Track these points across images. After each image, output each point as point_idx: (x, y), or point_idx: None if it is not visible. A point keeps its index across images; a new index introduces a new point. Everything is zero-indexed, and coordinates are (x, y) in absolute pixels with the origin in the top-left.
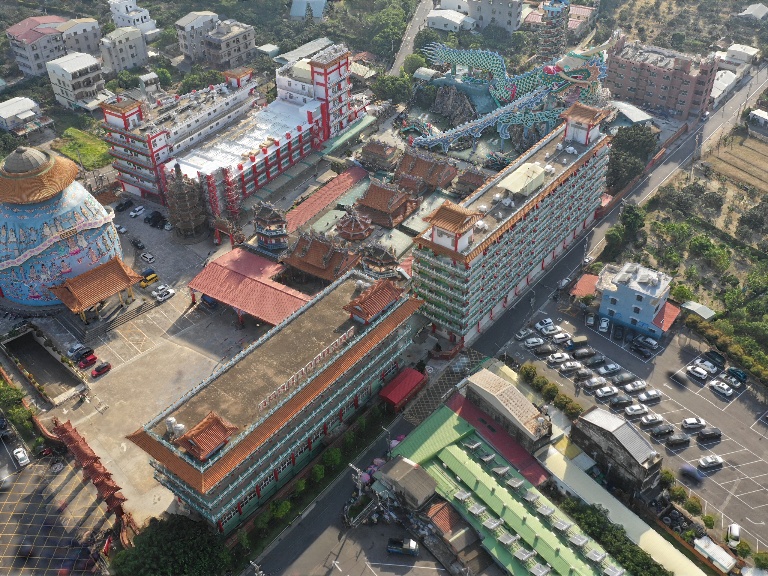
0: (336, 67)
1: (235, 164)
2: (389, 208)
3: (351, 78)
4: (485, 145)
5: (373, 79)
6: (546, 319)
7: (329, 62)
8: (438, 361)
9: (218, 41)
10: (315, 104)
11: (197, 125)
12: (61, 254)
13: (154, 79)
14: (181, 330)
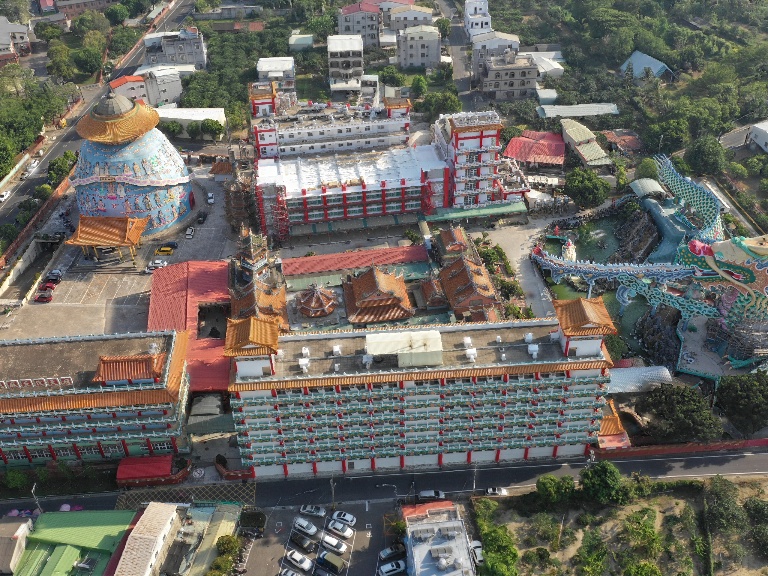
0: (477, 135)
1: (307, 187)
2: (359, 301)
3: (574, 157)
4: (611, 299)
5: (606, 169)
6: (348, 513)
7: (464, 126)
8: (216, 472)
9: (488, 68)
10: (439, 164)
11: (321, 137)
12: (101, 193)
13: (374, 82)
14: (123, 304)
